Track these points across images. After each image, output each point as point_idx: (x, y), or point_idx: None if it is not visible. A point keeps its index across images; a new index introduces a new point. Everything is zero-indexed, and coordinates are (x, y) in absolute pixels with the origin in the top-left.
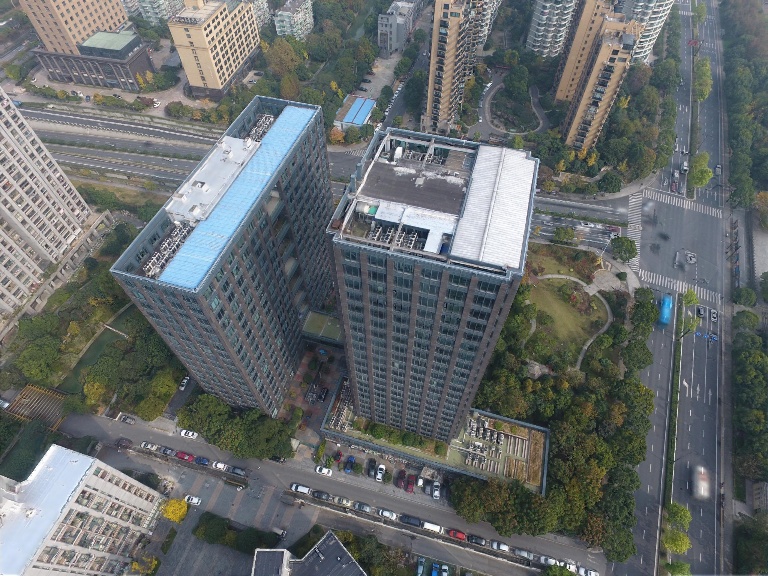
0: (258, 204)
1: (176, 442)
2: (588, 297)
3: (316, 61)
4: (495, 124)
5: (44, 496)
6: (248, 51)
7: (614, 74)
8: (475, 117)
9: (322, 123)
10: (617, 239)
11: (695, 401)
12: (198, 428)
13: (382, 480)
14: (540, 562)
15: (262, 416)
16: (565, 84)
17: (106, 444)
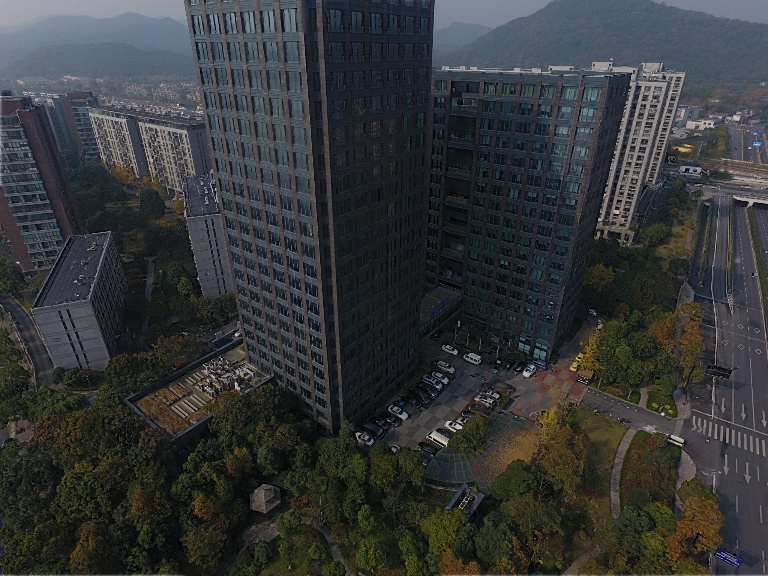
0: (443, 74)
1: None
2: None
3: None
4: None
5: None
6: None
7: None
8: None
9: (601, 101)
10: None
11: None
12: None
13: None
14: None
15: None
16: None
17: None
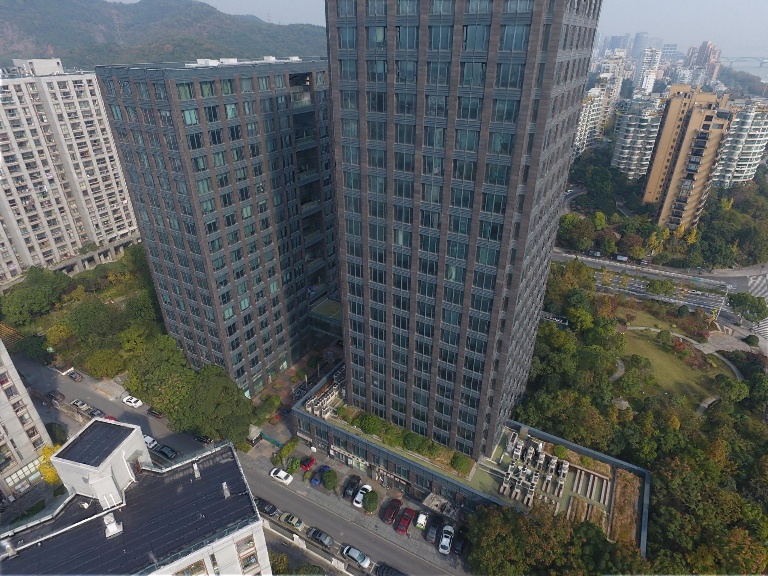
0: (279, 67)
1: (113, 408)
2: (702, 353)
3: None
4: (574, 213)
5: None
6: None
7: (710, 142)
8: None
9: None
10: (737, 293)
11: None
12: (140, 374)
13: (362, 505)
14: None
15: None
16: (654, 185)
17: (34, 391)
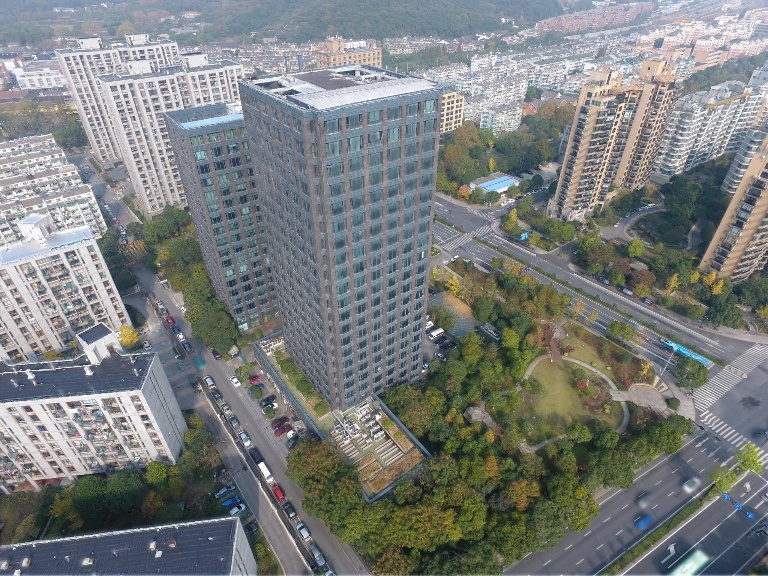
0: None
1: (175, 311)
2: (607, 398)
3: (498, 151)
4: (630, 232)
5: (57, 242)
6: (446, 129)
7: (766, 192)
8: (613, 222)
9: None
10: None
11: (670, 575)
12: (184, 296)
13: None
14: (325, 574)
15: (225, 311)
16: None
17: (141, 289)
